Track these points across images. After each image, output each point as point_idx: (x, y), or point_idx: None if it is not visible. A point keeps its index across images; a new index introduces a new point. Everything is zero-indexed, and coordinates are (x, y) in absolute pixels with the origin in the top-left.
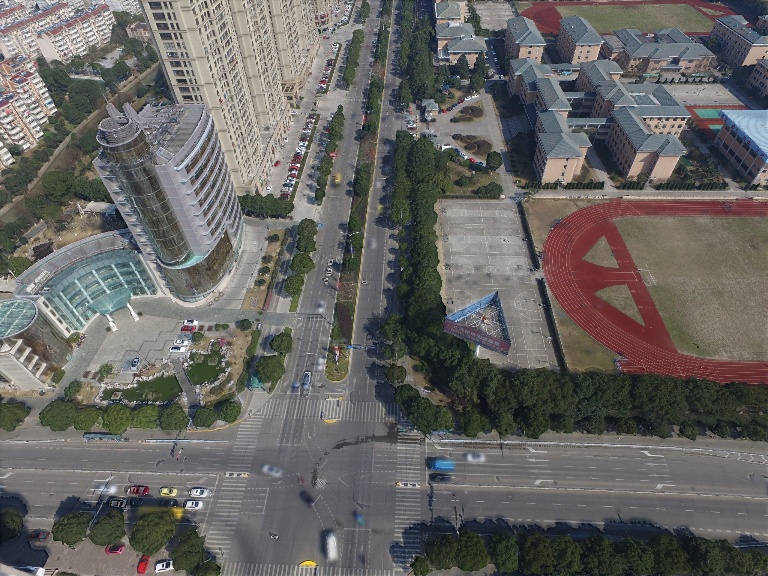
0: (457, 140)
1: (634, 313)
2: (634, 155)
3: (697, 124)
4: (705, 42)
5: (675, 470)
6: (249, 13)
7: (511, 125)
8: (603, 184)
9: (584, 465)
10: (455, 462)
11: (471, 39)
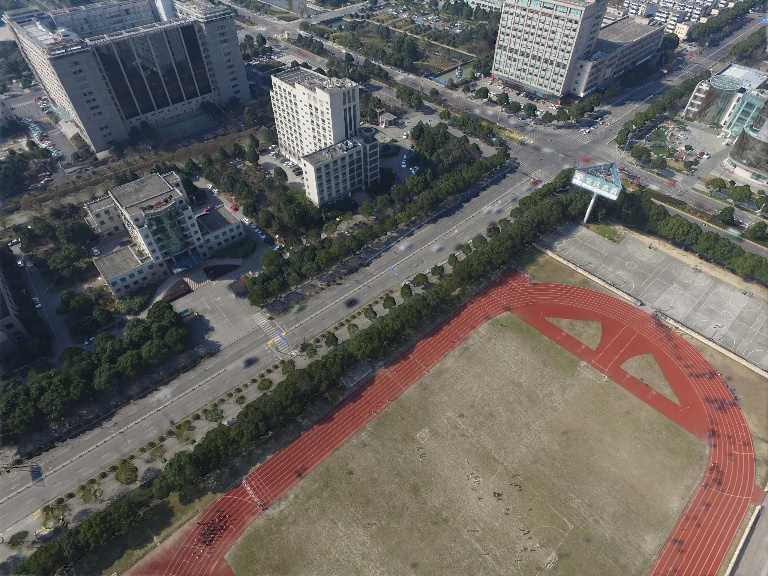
0: None
1: (561, 324)
2: None
3: None
4: None
5: (456, 242)
6: None
7: None
8: None
9: (491, 218)
10: (534, 188)
11: None
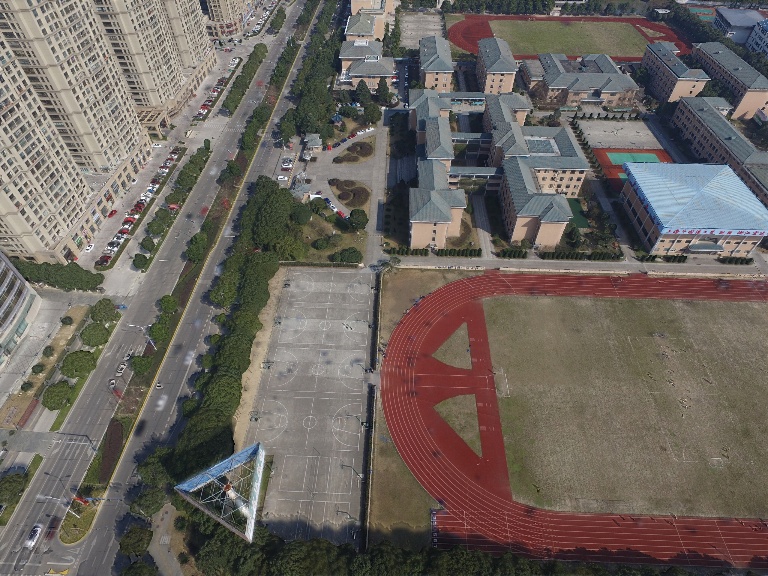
0: (333, 186)
1: (473, 438)
2: (515, 219)
3: (606, 172)
4: (633, 71)
5: None
6: (55, 39)
7: (399, 168)
8: (480, 251)
9: None
10: None
11: (376, 61)
